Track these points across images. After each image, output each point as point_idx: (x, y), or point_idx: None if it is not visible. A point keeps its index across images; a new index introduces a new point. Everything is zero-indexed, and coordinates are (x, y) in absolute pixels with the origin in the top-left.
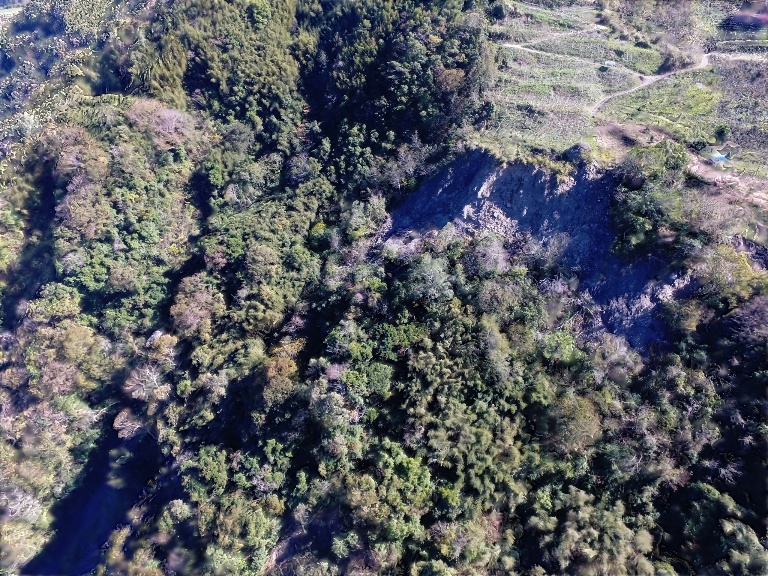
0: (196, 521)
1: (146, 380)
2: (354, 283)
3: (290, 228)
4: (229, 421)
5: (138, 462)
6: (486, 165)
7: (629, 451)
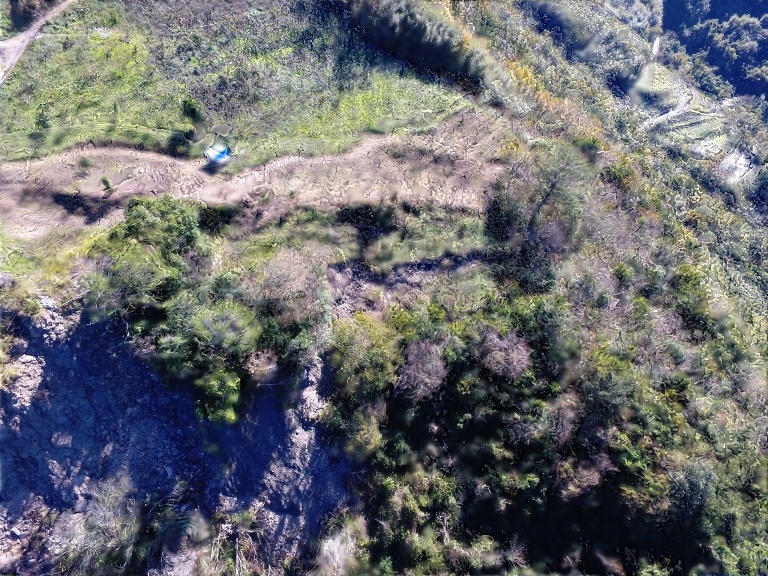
0: None
1: None
2: None
3: None
4: None
5: None
6: None
7: None
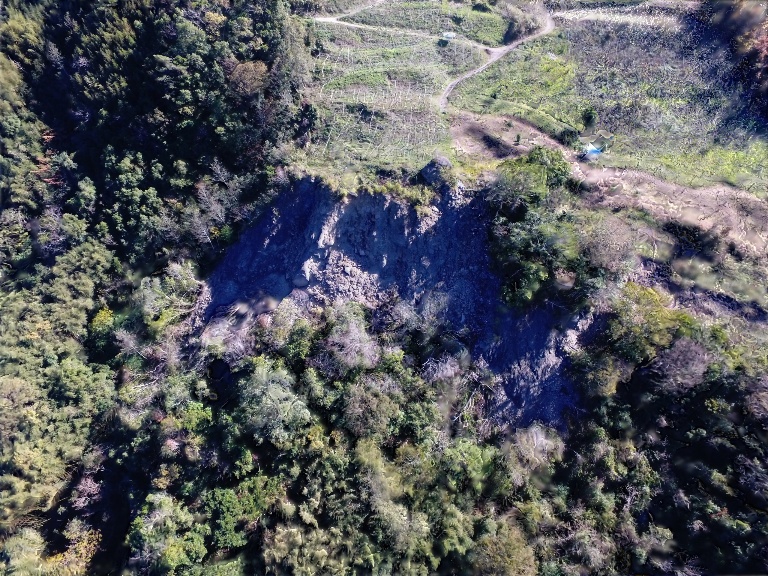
0: None
1: None
2: (165, 411)
3: (53, 331)
4: None
5: None
6: (321, 201)
7: None
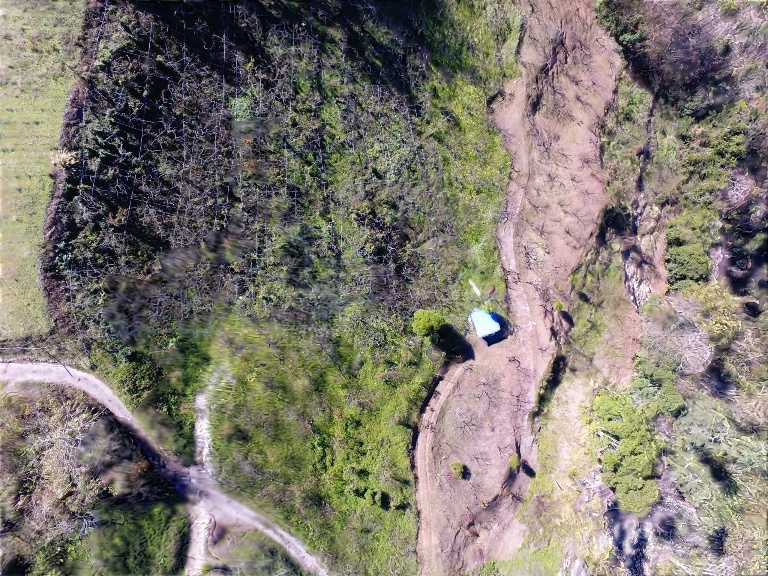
0: None
1: None
2: None
3: None
4: None
5: None
6: None
7: None
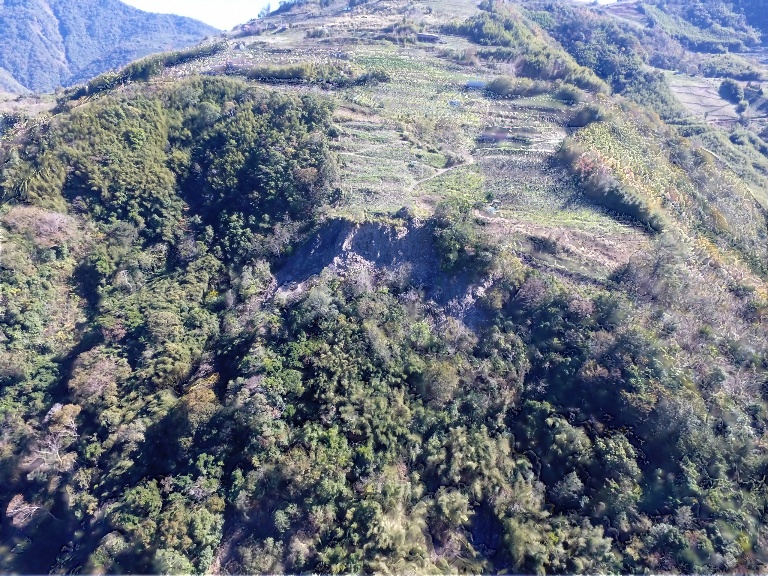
0: (138, 539)
1: (48, 453)
2: (254, 325)
3: (186, 297)
4: (151, 462)
5: (37, 549)
6: (345, 227)
7: (482, 393)
